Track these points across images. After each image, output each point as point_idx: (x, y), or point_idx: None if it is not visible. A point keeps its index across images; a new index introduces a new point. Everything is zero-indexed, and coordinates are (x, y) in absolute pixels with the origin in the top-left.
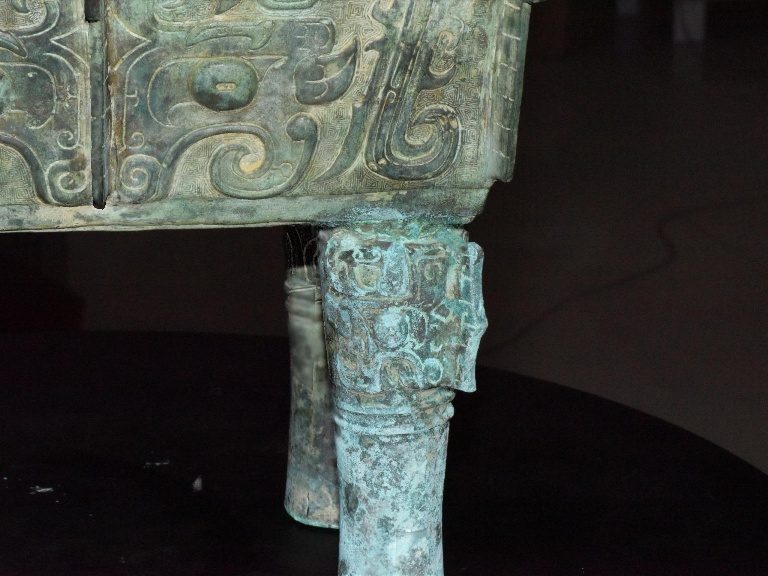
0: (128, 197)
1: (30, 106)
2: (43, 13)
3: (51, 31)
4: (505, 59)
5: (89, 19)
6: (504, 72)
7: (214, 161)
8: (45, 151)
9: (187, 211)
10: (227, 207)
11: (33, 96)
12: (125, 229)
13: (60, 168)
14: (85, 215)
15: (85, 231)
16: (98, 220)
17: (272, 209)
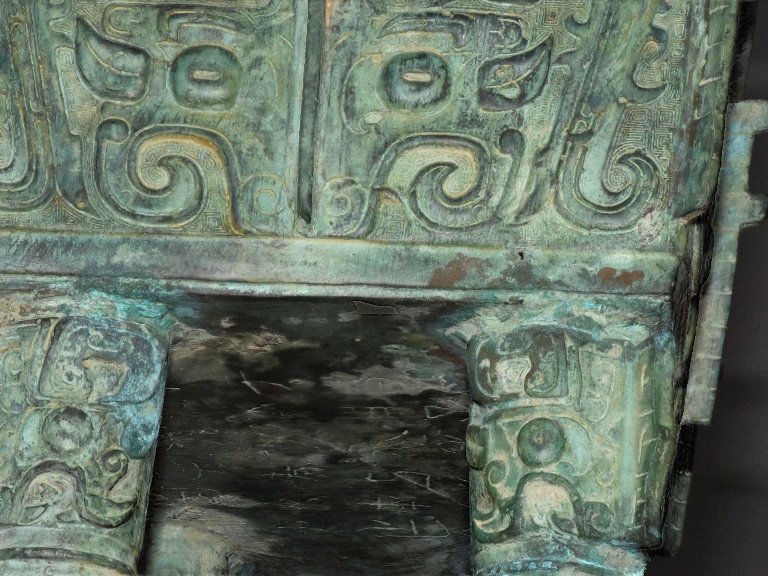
0: None
1: None
2: None
3: None
4: (681, 436)
5: (763, 220)
6: (680, 448)
7: None
8: None
9: None
10: None
11: None
12: None
13: None
14: None
15: None
16: None
17: None
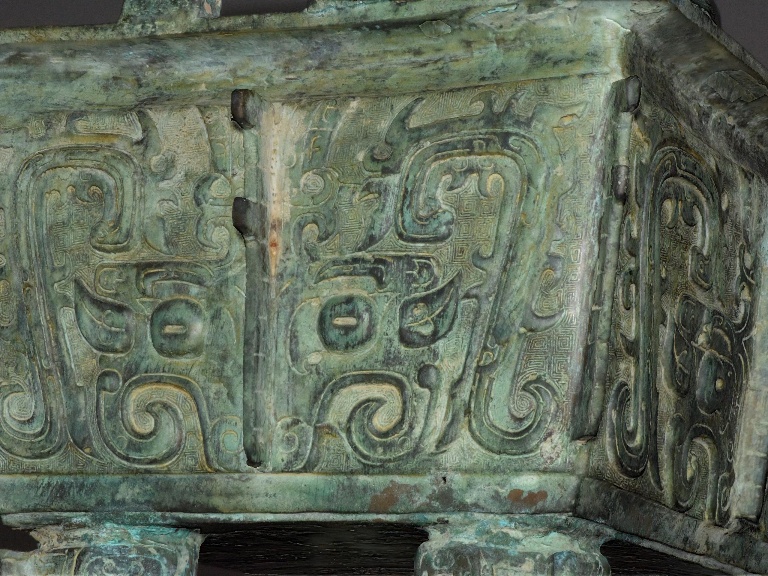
0: (740, 523)
1: (723, 408)
2: (740, 311)
3: (744, 331)
4: None
5: None
6: None
7: (766, 497)
8: (722, 460)
9: (741, 551)
10: (754, 551)
11: (726, 398)
12: (709, 565)
13: (725, 481)
14: (709, 541)
15: (694, 563)
16: (711, 549)
17: (767, 559)
